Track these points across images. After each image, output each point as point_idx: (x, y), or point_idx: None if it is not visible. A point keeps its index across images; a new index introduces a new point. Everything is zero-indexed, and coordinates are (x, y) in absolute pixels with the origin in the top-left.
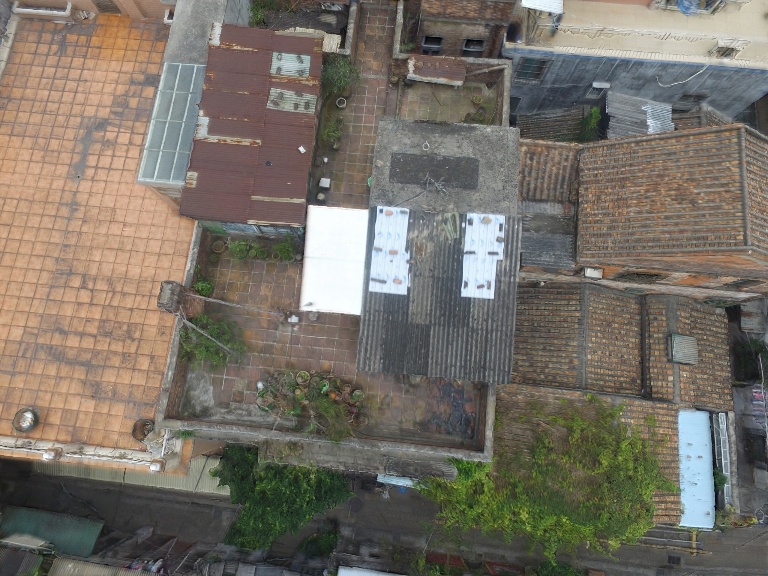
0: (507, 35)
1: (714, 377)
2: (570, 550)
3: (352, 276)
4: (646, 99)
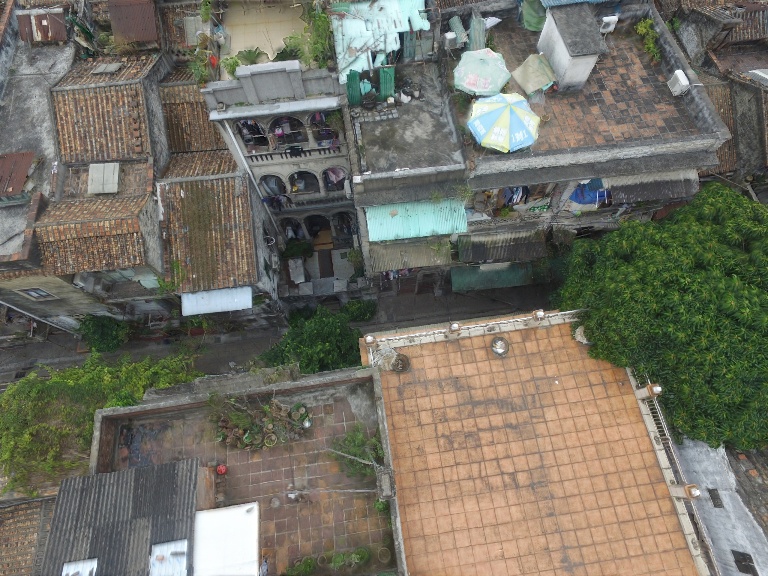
0: None
1: None
2: None
3: (207, 552)
4: None
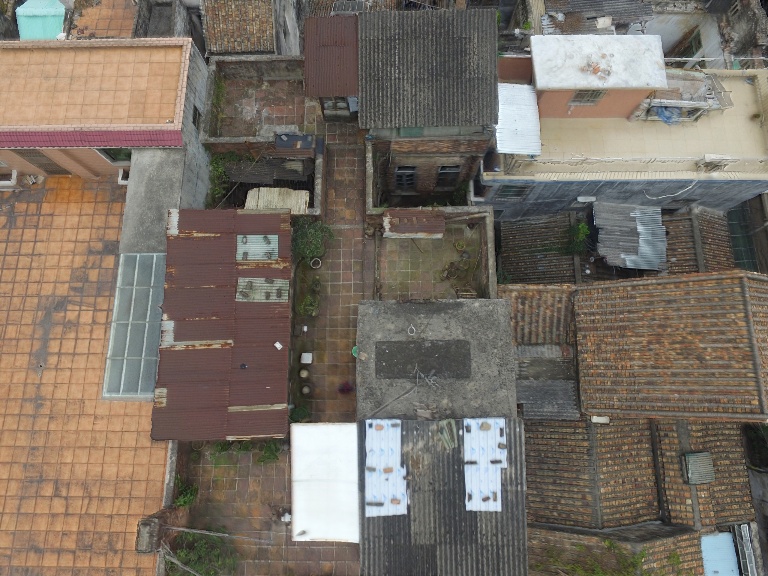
0: (484, 162)
1: (732, 486)
2: None
3: (346, 498)
4: (634, 205)
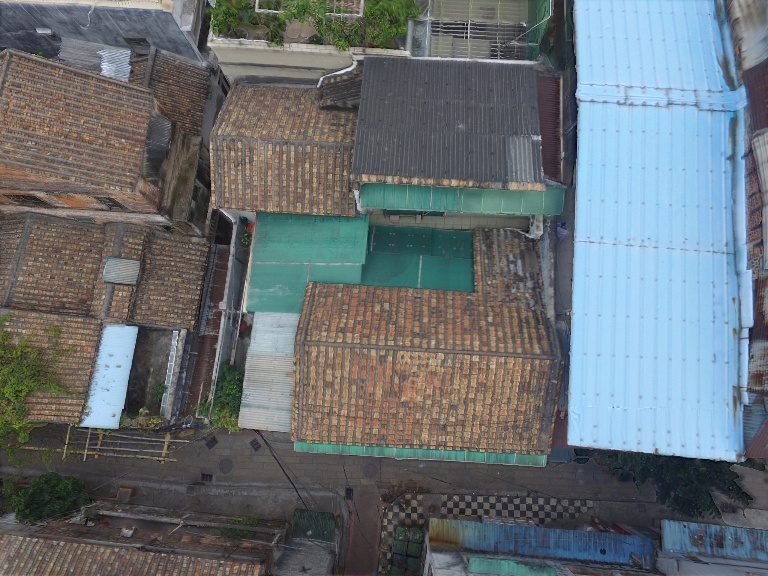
0: None
1: (175, 299)
2: (44, 461)
3: None
4: (101, 44)
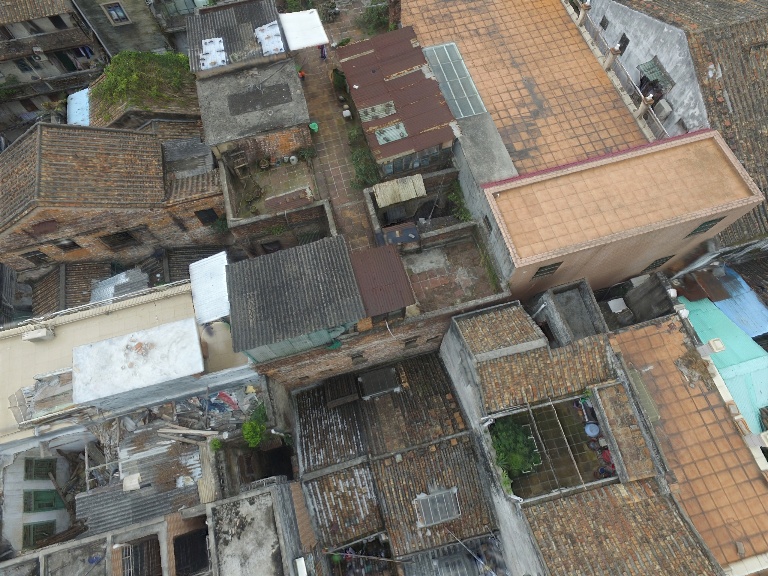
0: None
1: None
2: None
3: (290, 27)
4: None
